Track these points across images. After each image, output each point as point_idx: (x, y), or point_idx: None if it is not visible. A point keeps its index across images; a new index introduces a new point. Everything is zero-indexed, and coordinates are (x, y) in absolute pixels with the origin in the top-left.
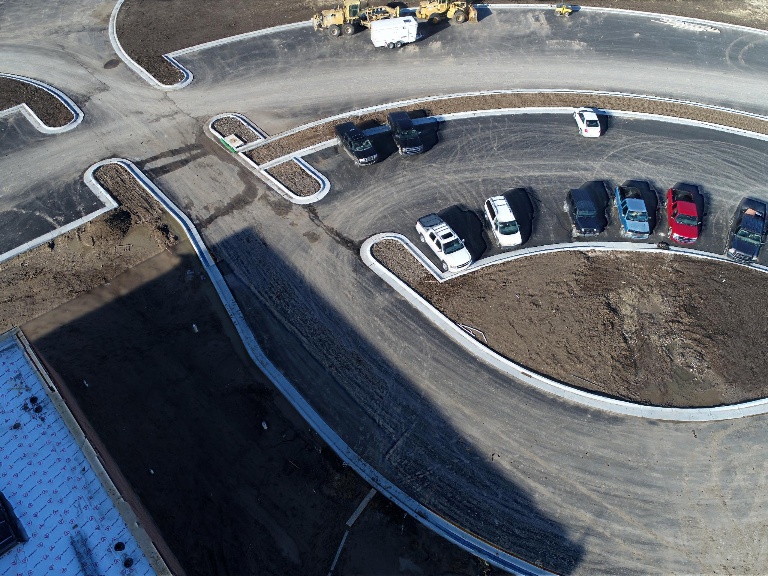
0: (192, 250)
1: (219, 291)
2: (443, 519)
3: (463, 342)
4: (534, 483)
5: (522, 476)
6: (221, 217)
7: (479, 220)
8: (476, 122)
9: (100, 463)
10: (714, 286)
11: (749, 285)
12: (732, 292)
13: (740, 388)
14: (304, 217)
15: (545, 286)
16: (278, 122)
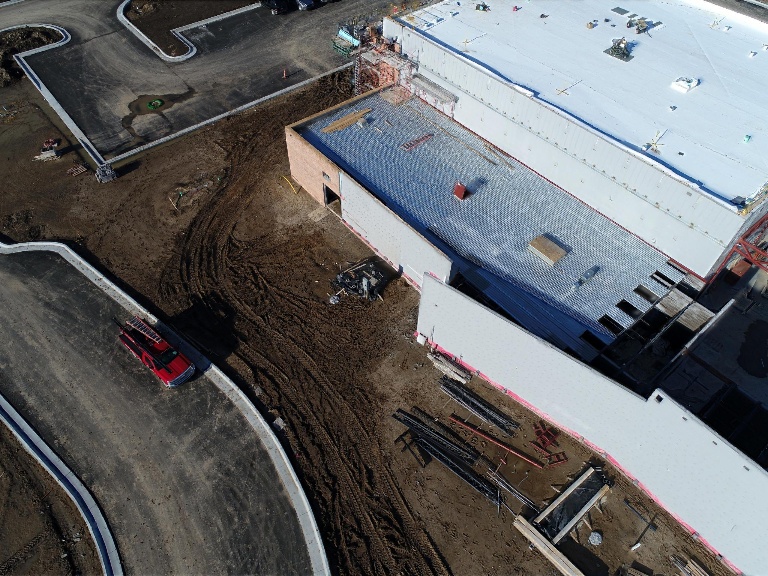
0: None
1: None
2: None
3: None
4: None
5: None
6: None
7: None
8: None
9: None
10: None
11: None
12: None
13: None
14: None
15: None
16: None
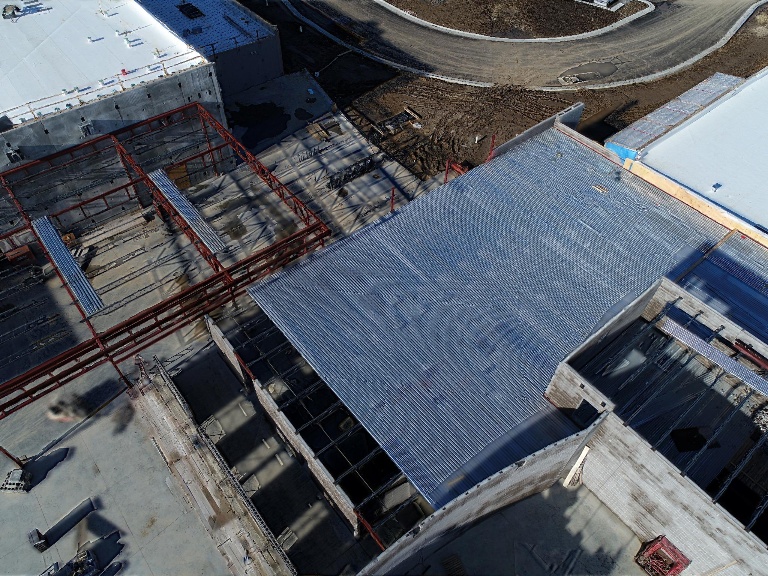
0: None
1: None
2: (382, 59)
3: (405, 16)
4: (428, 53)
5: (423, 51)
6: None
7: None
8: None
9: None
10: (547, 4)
11: (567, 5)
12: (556, 6)
13: (544, 35)
14: None
15: (454, 0)
16: None
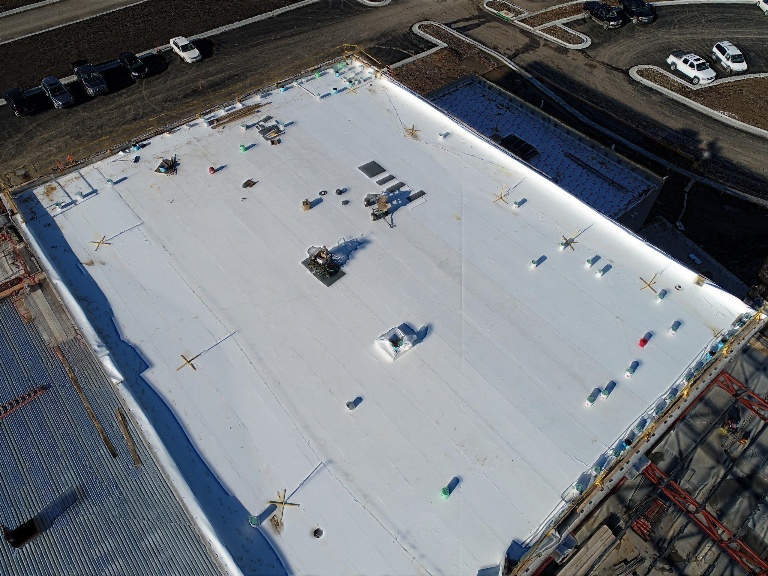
0: (512, 70)
1: (543, 90)
2: (742, 193)
3: (722, 119)
4: None
5: None
6: (522, 54)
7: (708, 60)
8: (683, 7)
9: (565, 125)
10: None
11: None
12: None
13: None
14: (580, 56)
15: None
16: (534, 4)
